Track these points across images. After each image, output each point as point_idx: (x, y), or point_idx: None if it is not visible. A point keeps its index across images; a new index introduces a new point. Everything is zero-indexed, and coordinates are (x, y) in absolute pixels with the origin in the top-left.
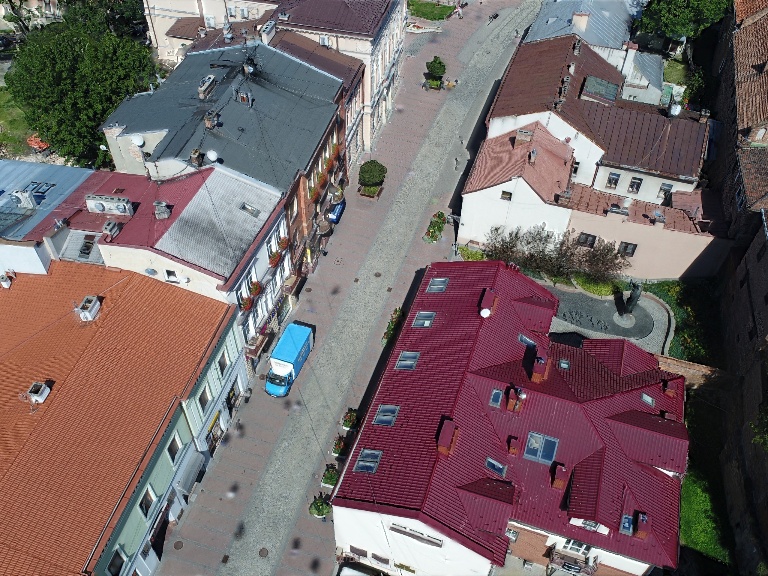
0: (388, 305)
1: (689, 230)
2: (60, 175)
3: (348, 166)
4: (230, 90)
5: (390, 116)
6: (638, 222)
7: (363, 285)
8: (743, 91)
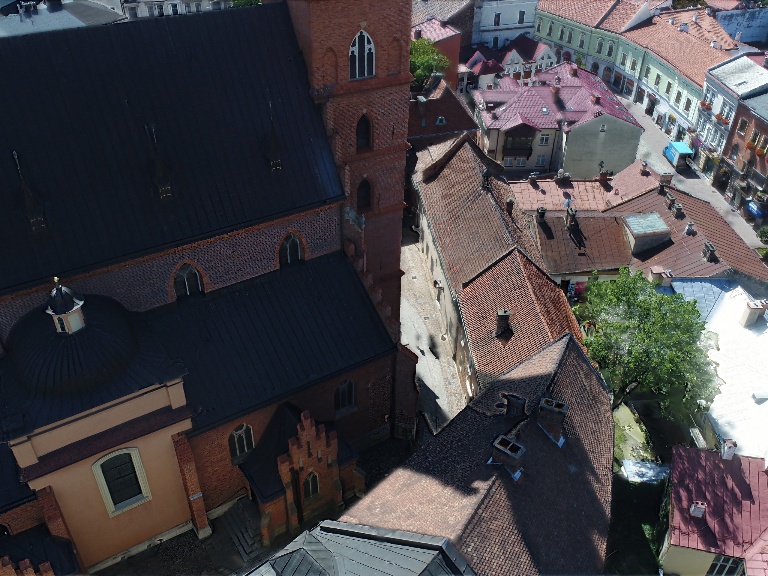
0: None
1: (511, 186)
2: None
3: None
4: None
5: None
6: (547, 180)
7: None
8: (520, 214)
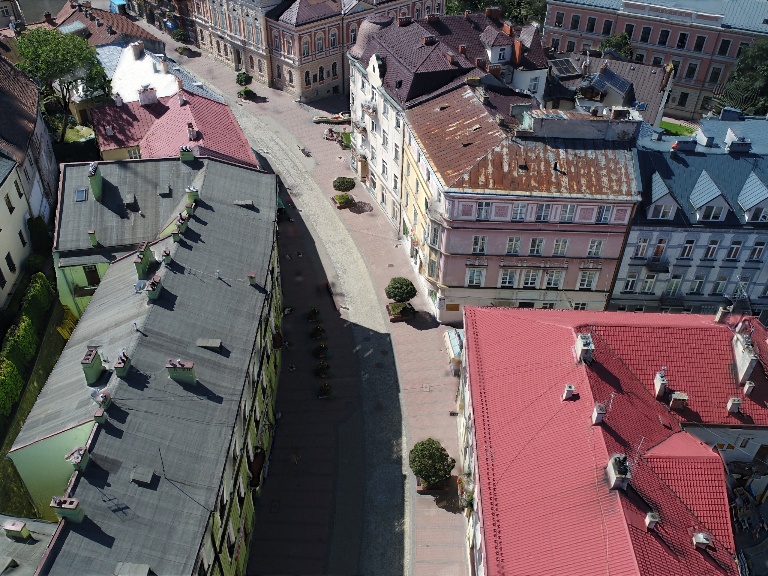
0: None
1: None
2: None
3: (201, 40)
4: None
5: (237, 73)
6: (6, 28)
7: None
8: None
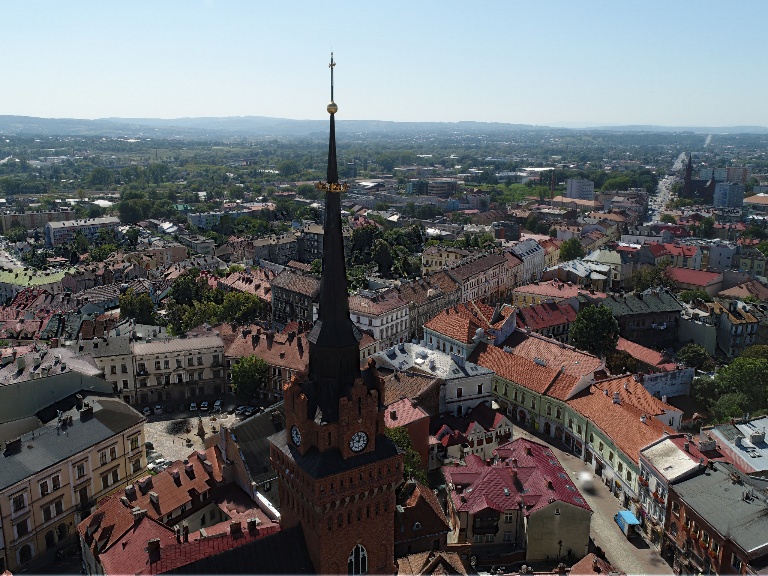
0: (619, 569)
1: None
2: (762, 463)
3: None
4: (762, 496)
5: None
6: (513, 573)
7: (643, 575)
8: None
